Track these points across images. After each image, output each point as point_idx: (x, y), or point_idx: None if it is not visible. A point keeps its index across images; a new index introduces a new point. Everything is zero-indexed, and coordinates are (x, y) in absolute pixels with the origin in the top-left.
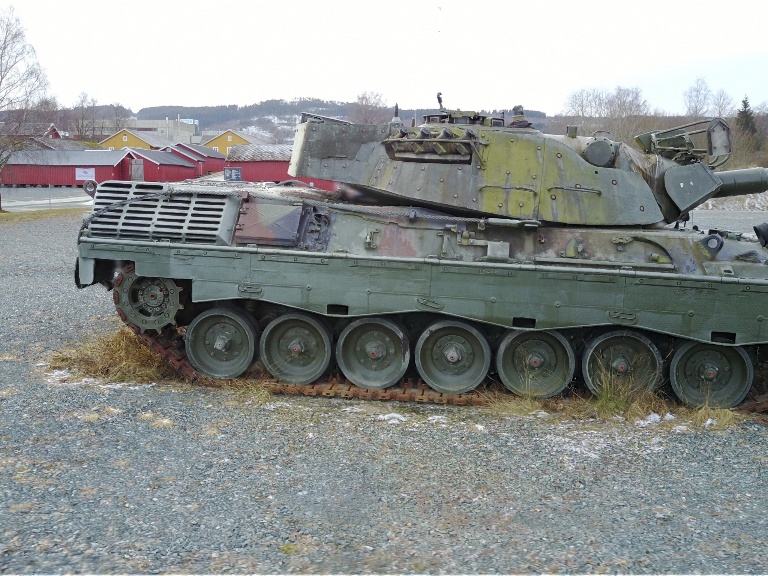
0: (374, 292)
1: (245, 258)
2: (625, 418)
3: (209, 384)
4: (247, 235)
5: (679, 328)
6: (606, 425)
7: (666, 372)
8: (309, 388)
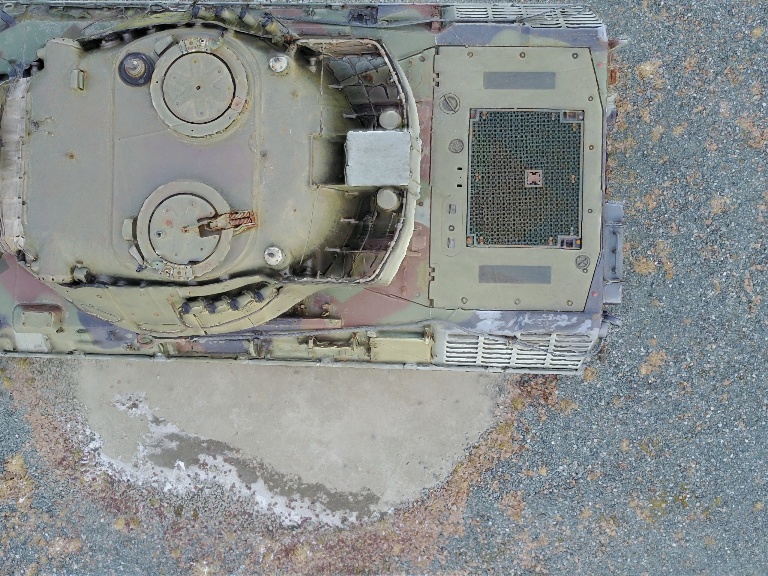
0: None
1: None
2: None
3: None
4: (426, 5)
5: None
6: None
7: None
8: None
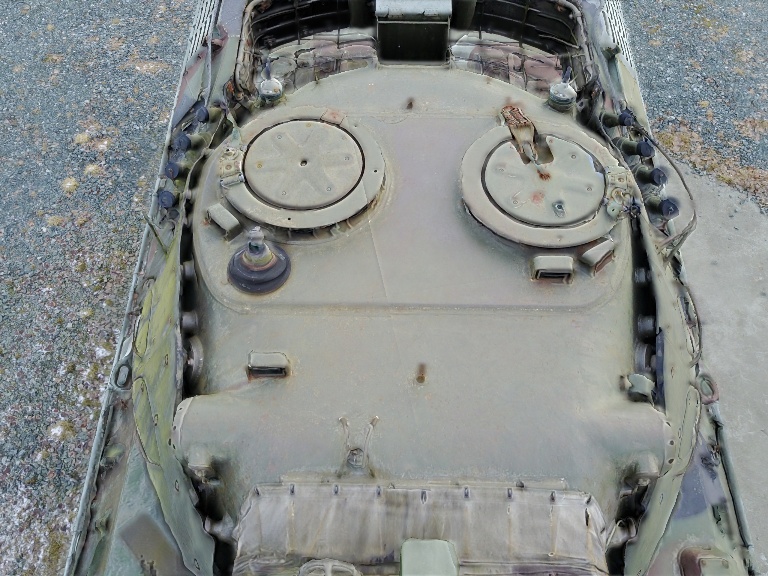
0: None
1: None
2: None
3: None
4: None
5: None
6: None
7: None
8: None
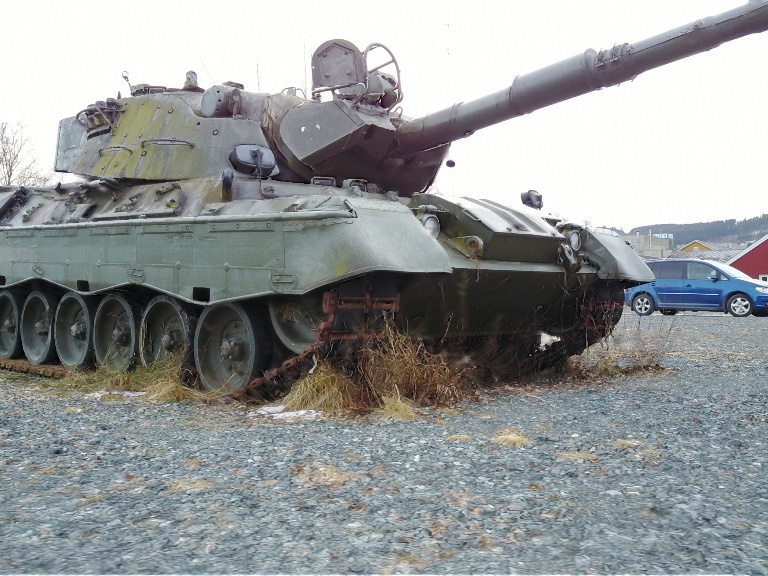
0: (15, 261)
1: None
2: None
3: None
4: None
5: (172, 285)
6: None
7: (191, 346)
8: None
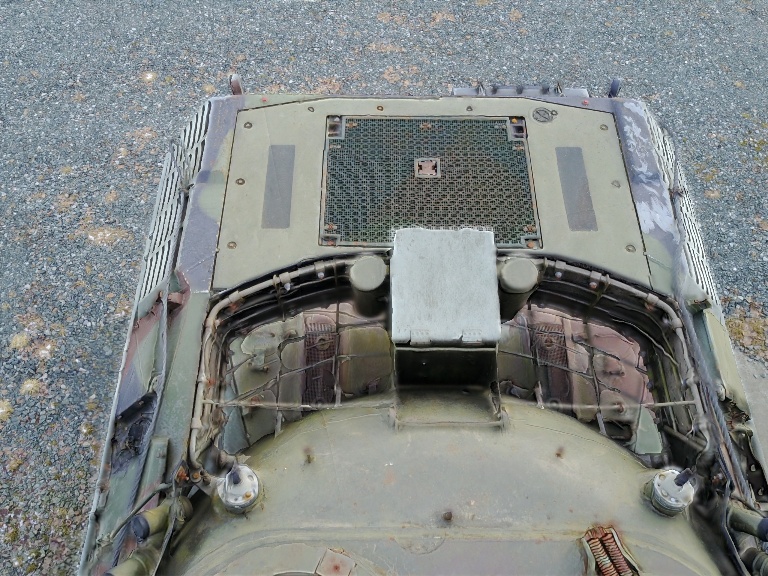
0: None
1: None
2: None
3: None
4: None
5: None
6: None
7: None
8: None
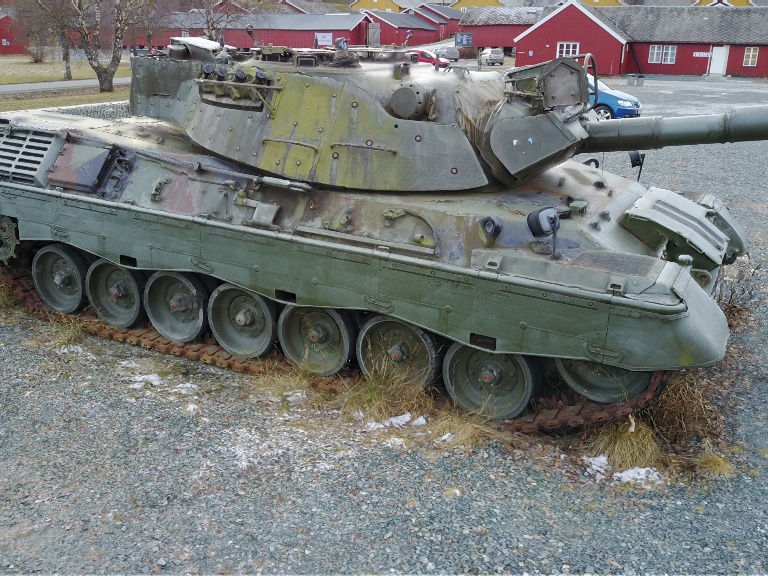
0: (155, 247)
1: (53, 201)
2: (364, 416)
3: (43, 317)
4: (56, 178)
5: (436, 324)
6: (329, 423)
7: (439, 368)
8: (121, 333)
